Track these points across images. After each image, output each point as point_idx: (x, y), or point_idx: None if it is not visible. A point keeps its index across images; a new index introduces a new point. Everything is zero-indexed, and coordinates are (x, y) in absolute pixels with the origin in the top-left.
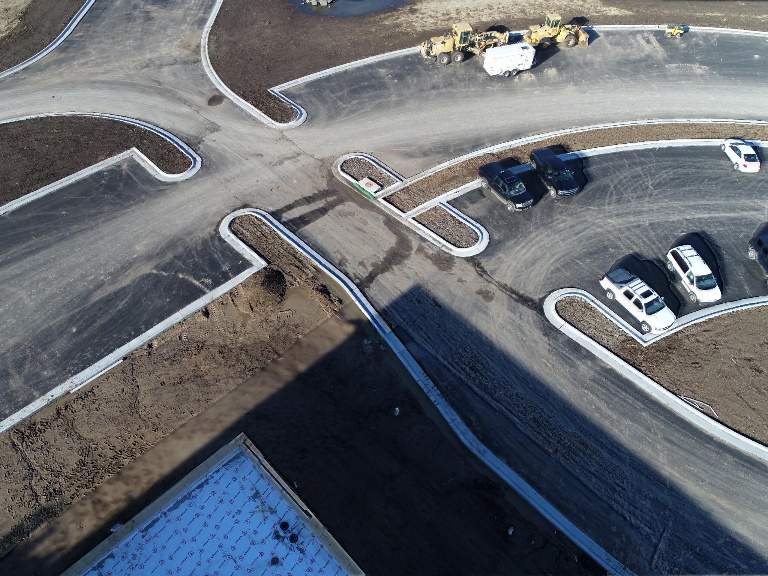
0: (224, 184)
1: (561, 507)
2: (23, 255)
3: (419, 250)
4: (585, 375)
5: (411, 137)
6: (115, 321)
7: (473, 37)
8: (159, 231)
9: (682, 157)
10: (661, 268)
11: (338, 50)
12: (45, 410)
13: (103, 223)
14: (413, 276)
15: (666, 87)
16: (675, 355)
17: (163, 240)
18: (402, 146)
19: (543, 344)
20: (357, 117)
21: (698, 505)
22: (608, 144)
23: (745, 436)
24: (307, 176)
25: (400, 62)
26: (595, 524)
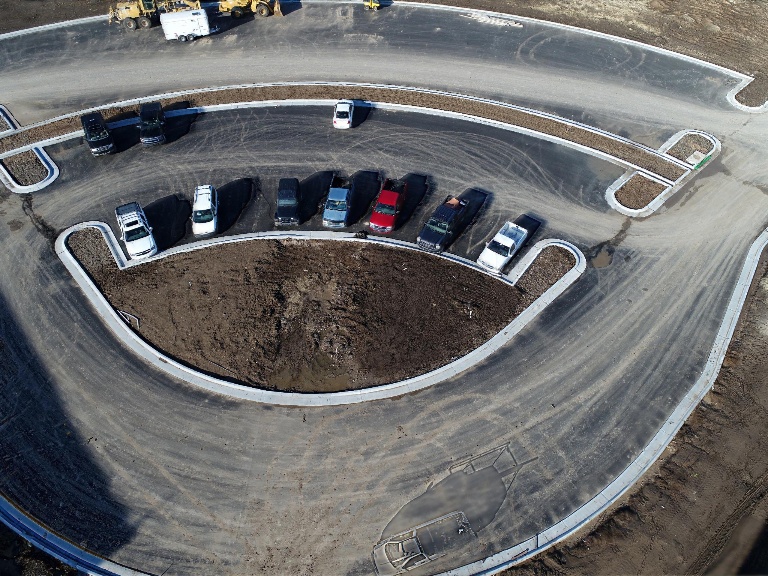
0: None
1: None
2: None
3: None
4: (50, 292)
5: (54, 91)
6: None
7: (160, 4)
8: None
9: (293, 114)
10: (192, 207)
11: (40, 14)
12: None
13: None
14: None
15: (329, 54)
16: (141, 278)
17: None
18: (39, 99)
19: (33, 266)
20: (16, 73)
21: (62, 397)
22: (233, 102)
23: (148, 344)
24: None
25: (93, 26)
26: None
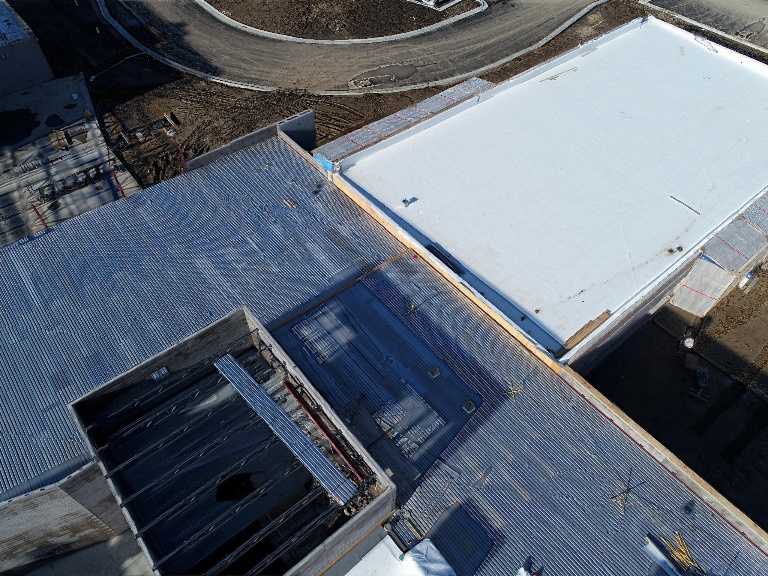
0: None
1: (130, 32)
2: None
3: None
4: (181, 4)
5: None
6: None
7: None
8: None
9: None
10: None
11: None
12: None
13: None
14: None
15: None
16: None
17: None
18: None
19: None
20: None
21: None
22: None
23: (237, 21)
24: None
25: None
26: (141, 36)
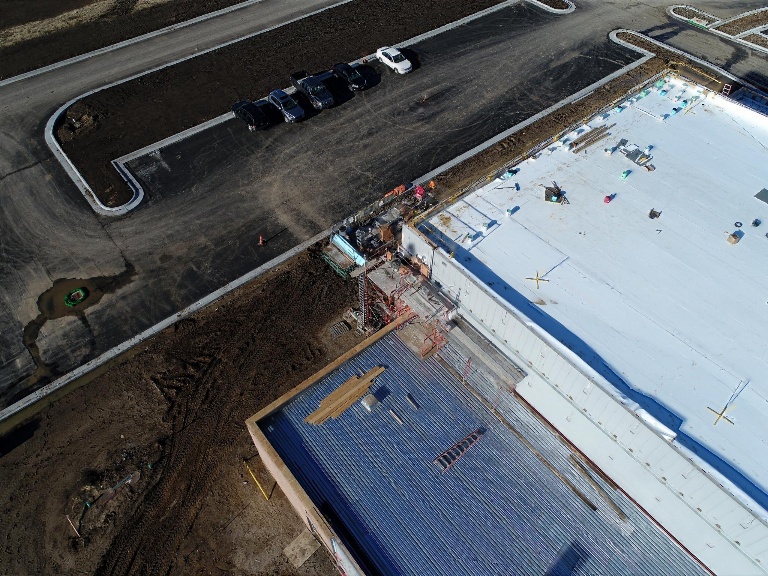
0: (597, 17)
1: None
2: (491, 44)
3: (753, 54)
4: None
5: None
6: (574, 76)
7: None
8: (570, 37)
9: None
10: None
11: None
12: (562, 109)
13: (531, 32)
14: (756, 66)
15: None
16: None
17: (576, 42)
18: (711, 2)
19: None
20: None
21: None
22: None
23: None
24: (652, 15)
25: None
26: None
